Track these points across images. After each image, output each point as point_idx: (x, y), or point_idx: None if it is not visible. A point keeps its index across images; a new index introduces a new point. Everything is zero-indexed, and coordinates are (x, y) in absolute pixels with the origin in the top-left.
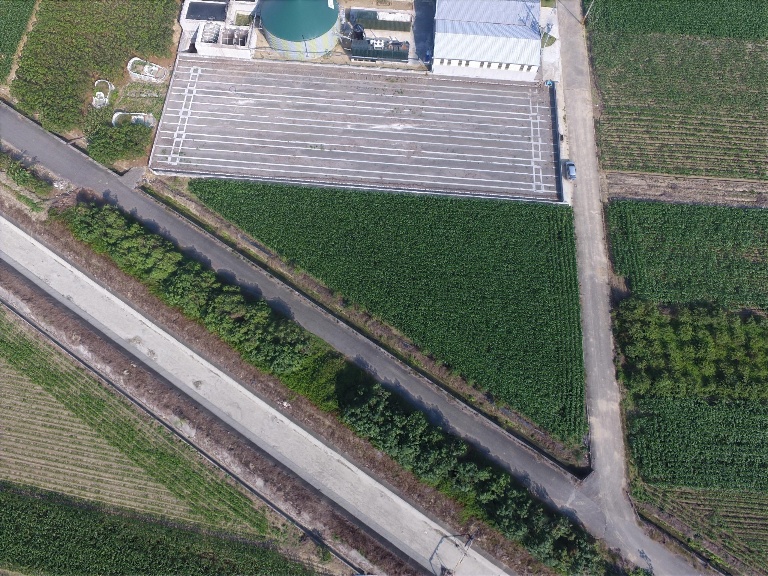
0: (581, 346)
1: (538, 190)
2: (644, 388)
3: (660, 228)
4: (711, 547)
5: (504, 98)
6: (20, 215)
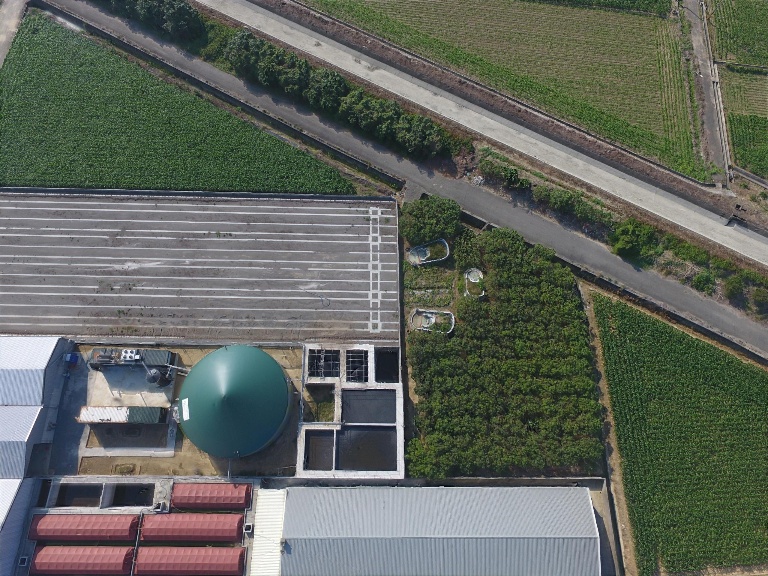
0: (1, 69)
1: None
2: None
3: None
4: None
5: None
6: (499, 146)
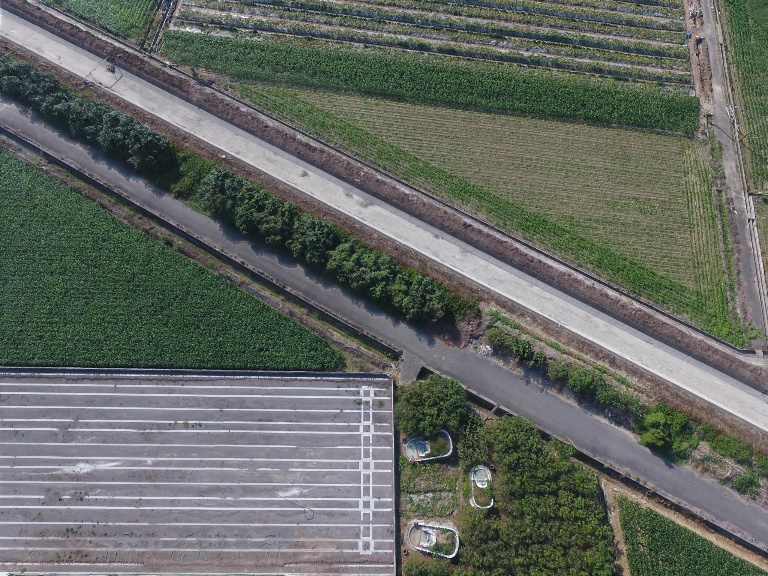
0: None
1: None
2: None
3: None
4: None
5: None
6: (509, 307)
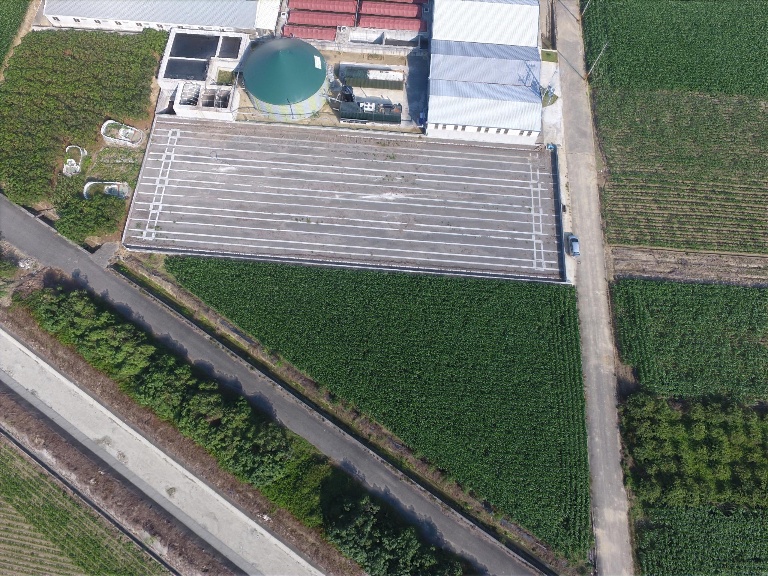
0: (586, 448)
1: (539, 268)
2: (654, 496)
3: (670, 311)
4: None
5: (503, 164)
6: None
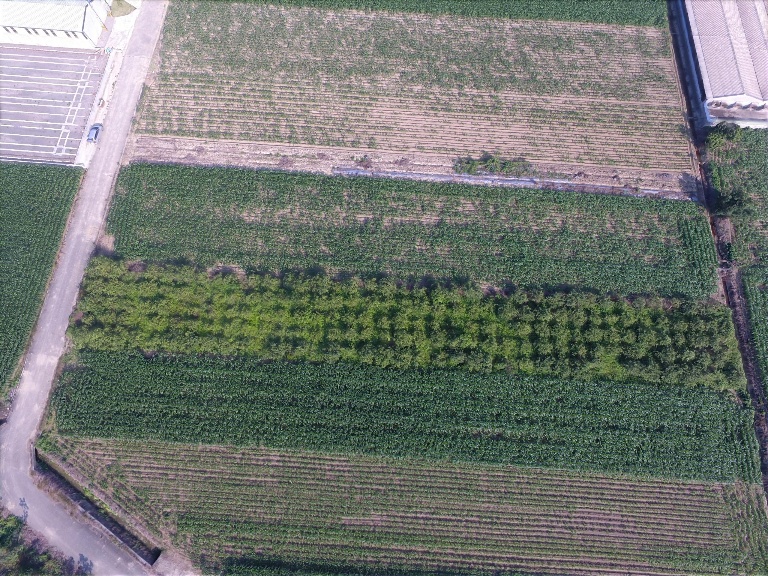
0: (34, 302)
1: (58, 153)
2: (83, 342)
3: (164, 189)
4: (99, 496)
5: (59, 65)
6: None
